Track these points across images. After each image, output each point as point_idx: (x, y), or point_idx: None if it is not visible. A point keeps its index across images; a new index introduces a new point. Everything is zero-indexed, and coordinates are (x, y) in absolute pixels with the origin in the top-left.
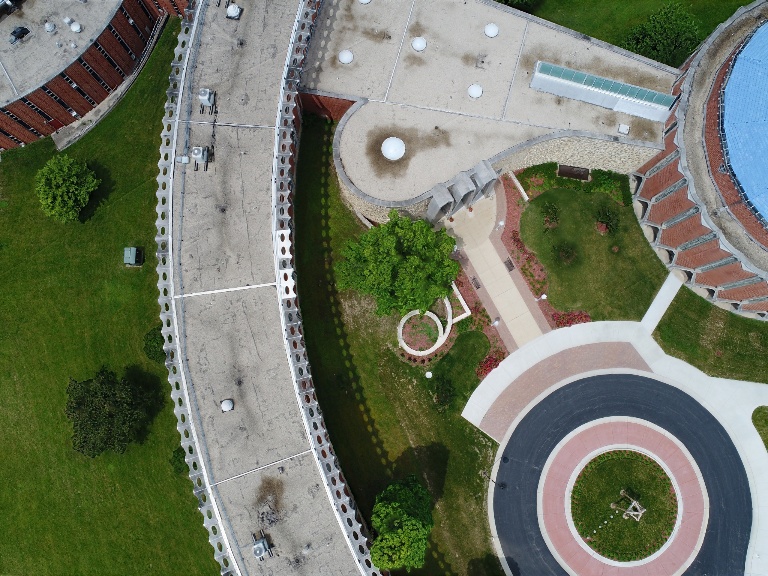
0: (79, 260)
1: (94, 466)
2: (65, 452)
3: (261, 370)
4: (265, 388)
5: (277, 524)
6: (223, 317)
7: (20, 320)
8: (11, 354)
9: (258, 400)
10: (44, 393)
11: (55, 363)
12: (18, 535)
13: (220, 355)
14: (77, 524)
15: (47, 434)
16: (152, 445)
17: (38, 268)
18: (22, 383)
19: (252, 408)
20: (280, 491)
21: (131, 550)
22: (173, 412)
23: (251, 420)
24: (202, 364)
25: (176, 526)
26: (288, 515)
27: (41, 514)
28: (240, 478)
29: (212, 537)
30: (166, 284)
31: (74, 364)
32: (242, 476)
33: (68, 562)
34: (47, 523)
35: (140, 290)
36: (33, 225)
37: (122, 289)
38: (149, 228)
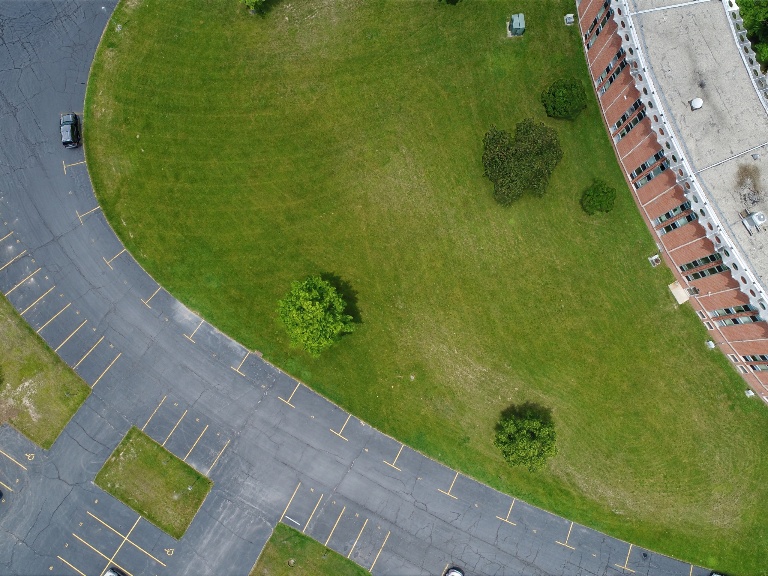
0: (456, 38)
1: (494, 223)
2: (463, 213)
3: (720, 73)
4: (727, 88)
5: (759, 203)
6: (677, 29)
7: (401, 99)
8: (397, 131)
9: (722, 99)
10: (435, 162)
11: (443, 134)
12: (427, 293)
13: (680, 62)
14: (484, 277)
15: (443, 199)
16: (551, 197)
17: (412, 51)
18: (412, 155)
19: (718, 106)
20: (757, 175)
21: (541, 295)
22: (570, 164)
23: (719, 116)
24: (666, 71)
25: (585, 267)
26: (767, 195)
27: (447, 271)
28: (718, 166)
29: (702, 218)
30: (619, 4)
31: (463, 132)
32: (720, 164)
33: (479, 312)
34: (454, 279)
35: (524, 57)
36: (399, 14)
37: (505, 58)
38: (525, 1)
